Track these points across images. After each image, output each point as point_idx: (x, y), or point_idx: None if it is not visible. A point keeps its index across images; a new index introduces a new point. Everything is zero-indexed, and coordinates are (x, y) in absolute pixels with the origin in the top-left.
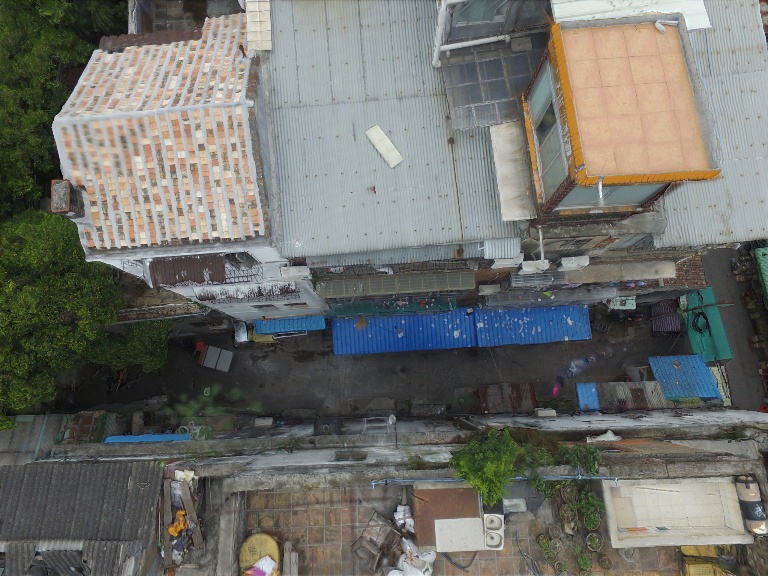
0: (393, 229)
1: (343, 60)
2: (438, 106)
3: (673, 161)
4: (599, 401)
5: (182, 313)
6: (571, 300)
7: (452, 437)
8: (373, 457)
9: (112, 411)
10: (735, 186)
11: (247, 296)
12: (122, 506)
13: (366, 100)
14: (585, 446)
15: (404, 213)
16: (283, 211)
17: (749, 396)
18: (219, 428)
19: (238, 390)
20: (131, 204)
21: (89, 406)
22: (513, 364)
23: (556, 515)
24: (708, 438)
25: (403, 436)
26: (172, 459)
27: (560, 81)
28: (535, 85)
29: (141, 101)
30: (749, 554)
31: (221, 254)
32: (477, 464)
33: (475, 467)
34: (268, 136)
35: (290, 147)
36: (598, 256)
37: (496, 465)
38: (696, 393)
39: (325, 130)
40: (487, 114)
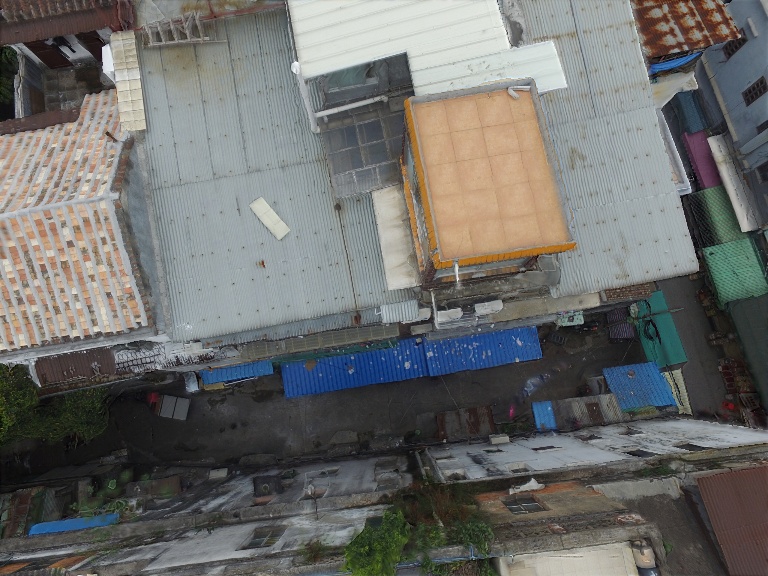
0: (285, 303)
1: (221, 132)
2: (322, 172)
3: (529, 236)
4: (555, 419)
5: (115, 379)
6: (511, 327)
7: (379, 497)
8: (284, 539)
9: (51, 486)
10: (628, 228)
11: (166, 366)
12: None
13: (248, 172)
14: (477, 525)
15: (295, 285)
16: (171, 294)
17: (710, 394)
18: (165, 491)
19: (198, 437)
20: (4, 307)
21: (41, 472)
22: (473, 384)
23: None
24: (632, 477)
25: (329, 501)
26: (87, 553)
27: (413, 159)
28: (405, 152)
29: (5, 201)
30: None
31: (108, 347)
32: (360, 561)
33: (359, 564)
34: (149, 219)
35: (173, 227)
36: (515, 296)
37: (372, 567)
38: (651, 402)
39: (208, 207)
40: (368, 179)
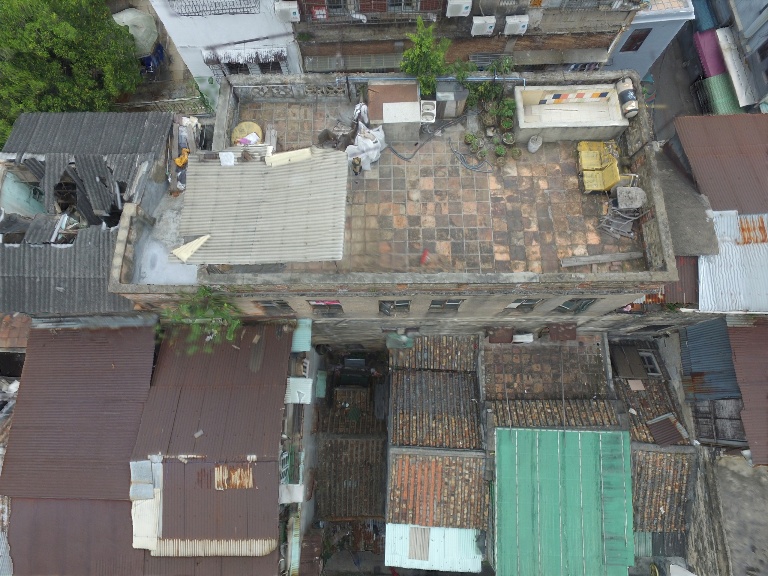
0: None
1: None
2: None
3: None
4: None
5: None
6: None
7: None
8: None
9: None
10: None
11: (246, 61)
12: (139, 136)
13: None
14: None
15: None
16: None
17: None
18: None
19: None
20: None
21: None
22: None
23: (481, 128)
24: None
25: None
26: None
27: None
28: None
29: None
30: (629, 149)
31: None
32: None
33: None
34: None
35: None
36: (539, 27)
37: None
38: None
39: None
40: None
